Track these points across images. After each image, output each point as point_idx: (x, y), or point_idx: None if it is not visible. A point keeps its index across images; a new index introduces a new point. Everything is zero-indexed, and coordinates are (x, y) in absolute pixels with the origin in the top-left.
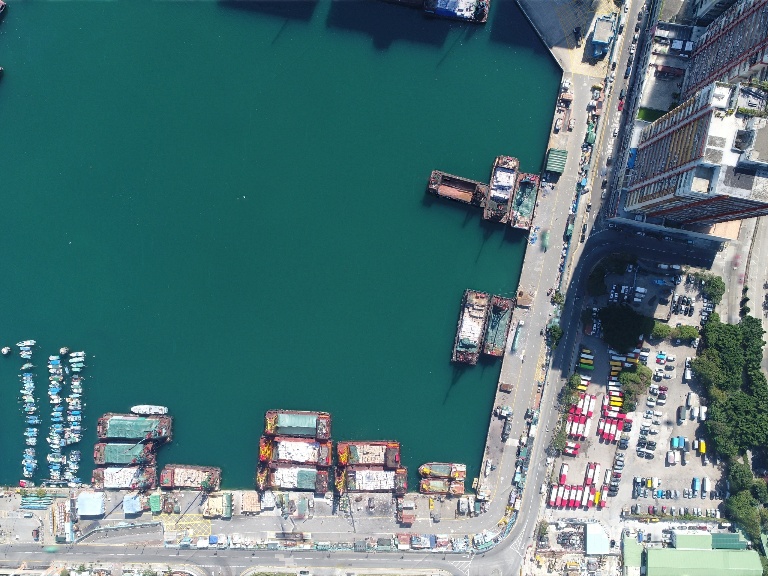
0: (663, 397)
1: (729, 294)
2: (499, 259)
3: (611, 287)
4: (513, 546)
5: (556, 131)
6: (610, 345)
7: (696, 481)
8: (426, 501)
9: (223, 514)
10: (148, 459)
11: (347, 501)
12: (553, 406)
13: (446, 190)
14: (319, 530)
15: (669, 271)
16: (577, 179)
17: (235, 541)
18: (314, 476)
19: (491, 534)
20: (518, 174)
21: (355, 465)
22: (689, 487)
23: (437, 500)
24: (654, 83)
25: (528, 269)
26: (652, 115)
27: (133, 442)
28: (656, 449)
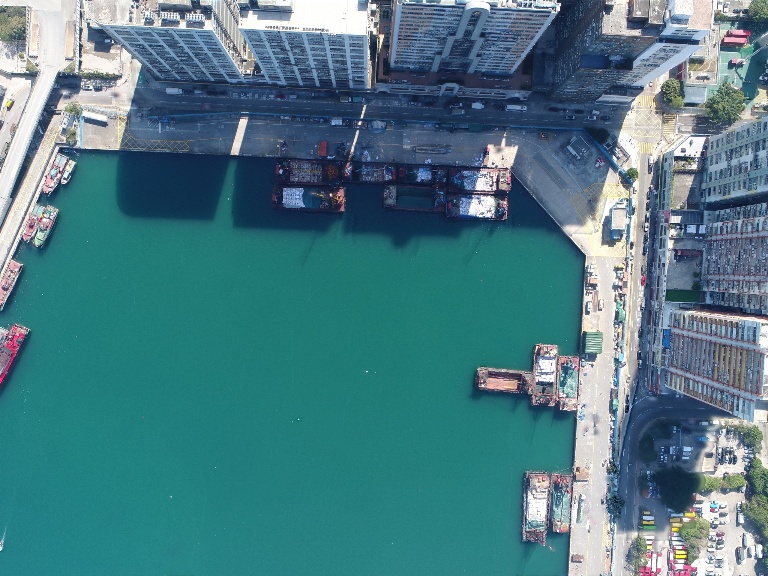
0: (721, 542)
1: (766, 438)
2: (552, 438)
3: (660, 450)
4: None
5: (587, 312)
6: None
7: None
8: None
9: None
10: None
11: None
12: (623, 567)
13: (492, 381)
14: None
15: (709, 426)
16: (613, 354)
17: None
18: None
19: None
20: (558, 358)
21: None
22: None
23: None
24: (675, 265)
25: (581, 445)
26: (678, 295)
27: None
28: None
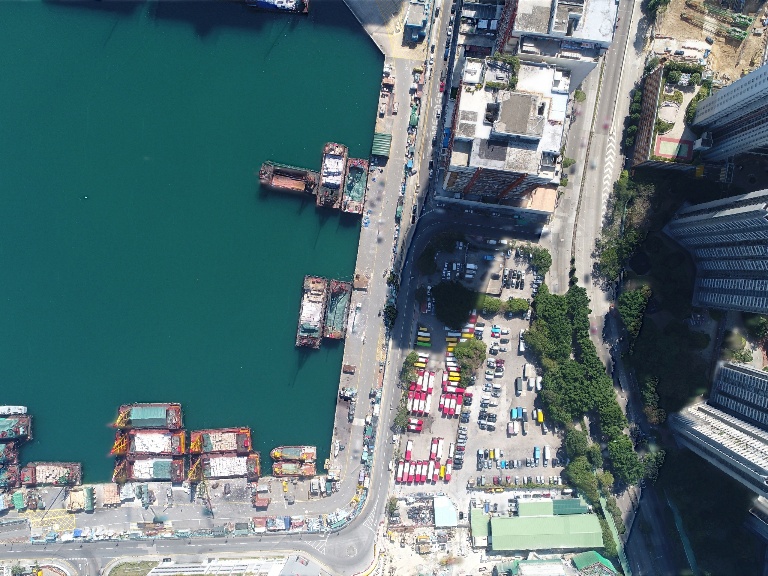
0: (500, 370)
1: (558, 265)
2: (336, 244)
3: (443, 265)
4: (366, 523)
5: (381, 115)
6: (444, 322)
7: (536, 450)
8: (280, 484)
9: (84, 507)
10: (9, 458)
11: (203, 488)
12: (395, 385)
13: (280, 179)
14: (179, 518)
15: (499, 246)
16: (405, 161)
17: (97, 533)
18: (169, 466)
19: (344, 513)
20: (347, 160)
21: (209, 453)
22: (531, 456)
23: (290, 482)
24: None
25: (363, 252)
26: None
27: None
28: (497, 421)
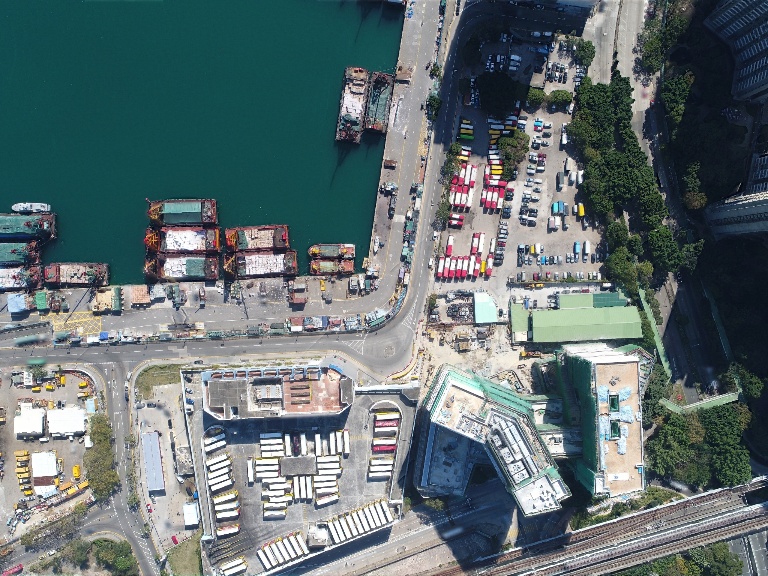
0: (542, 164)
1: (600, 60)
2: (378, 37)
3: (487, 57)
4: (405, 322)
5: None
6: (488, 113)
7: (576, 244)
8: (317, 283)
9: (112, 307)
10: (31, 255)
11: (238, 287)
12: (437, 180)
13: None
14: (211, 319)
15: (542, 40)
16: None
17: (126, 333)
18: (203, 262)
19: (383, 311)
20: None
21: (244, 251)
22: (571, 252)
23: (328, 281)
24: None
25: (406, 44)
26: None
27: (16, 242)
28: (538, 216)
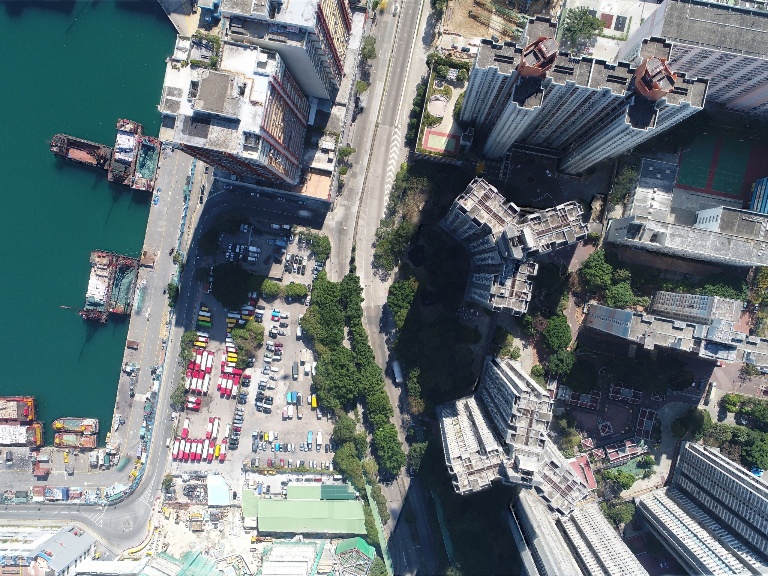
0: (278, 353)
1: (339, 253)
2: (127, 220)
3: (228, 247)
4: (143, 498)
5: None
6: None
7: (308, 434)
8: (61, 455)
9: None
10: None
11: None
12: (177, 362)
13: (76, 153)
14: None
15: (283, 231)
16: None
17: None
18: None
19: (122, 486)
20: (140, 137)
21: None
22: (305, 440)
23: (71, 454)
24: None
25: (152, 229)
26: None
27: None
28: (274, 404)
